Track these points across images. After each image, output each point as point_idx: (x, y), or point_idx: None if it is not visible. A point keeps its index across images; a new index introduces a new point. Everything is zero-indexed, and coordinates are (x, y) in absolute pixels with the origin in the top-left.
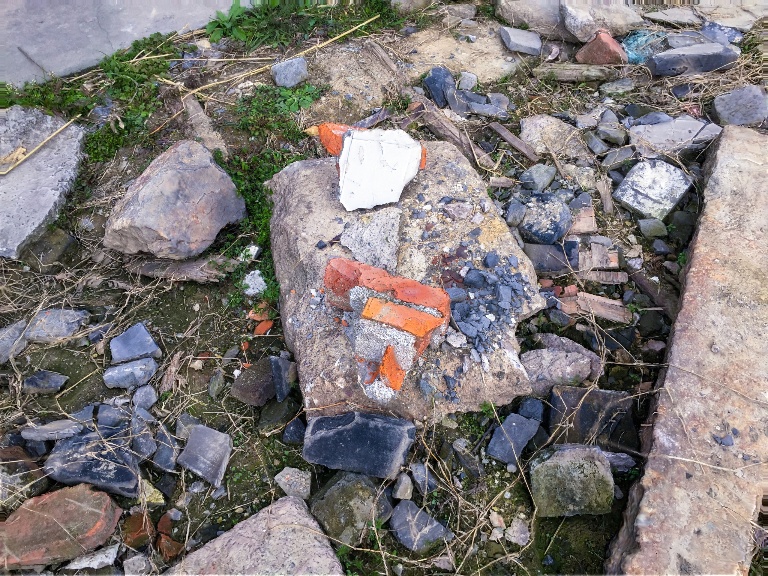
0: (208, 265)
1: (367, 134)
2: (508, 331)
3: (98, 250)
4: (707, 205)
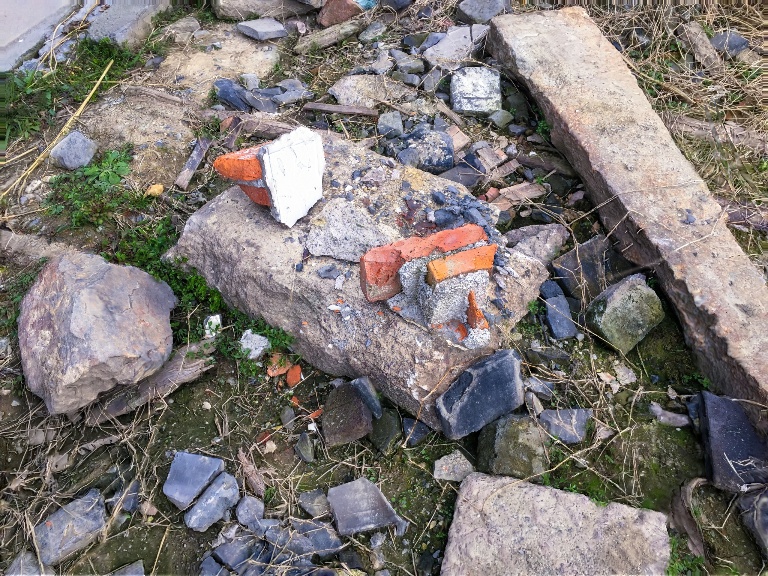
0: (186, 360)
1: (278, 144)
2: (503, 240)
3: (33, 430)
4: (532, 79)
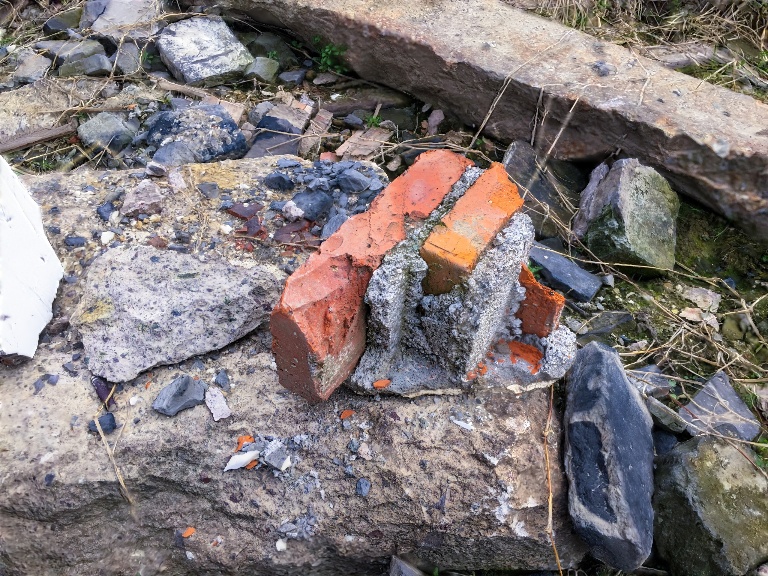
0: None
1: None
2: None
3: None
4: None
